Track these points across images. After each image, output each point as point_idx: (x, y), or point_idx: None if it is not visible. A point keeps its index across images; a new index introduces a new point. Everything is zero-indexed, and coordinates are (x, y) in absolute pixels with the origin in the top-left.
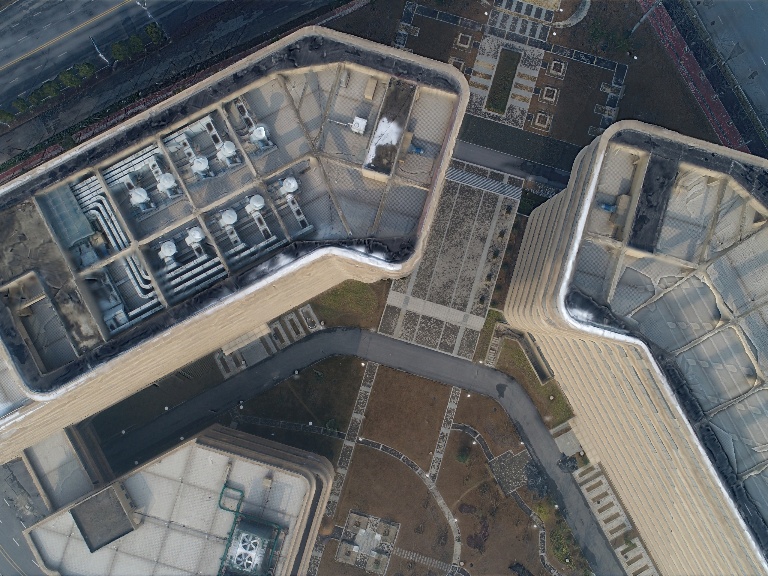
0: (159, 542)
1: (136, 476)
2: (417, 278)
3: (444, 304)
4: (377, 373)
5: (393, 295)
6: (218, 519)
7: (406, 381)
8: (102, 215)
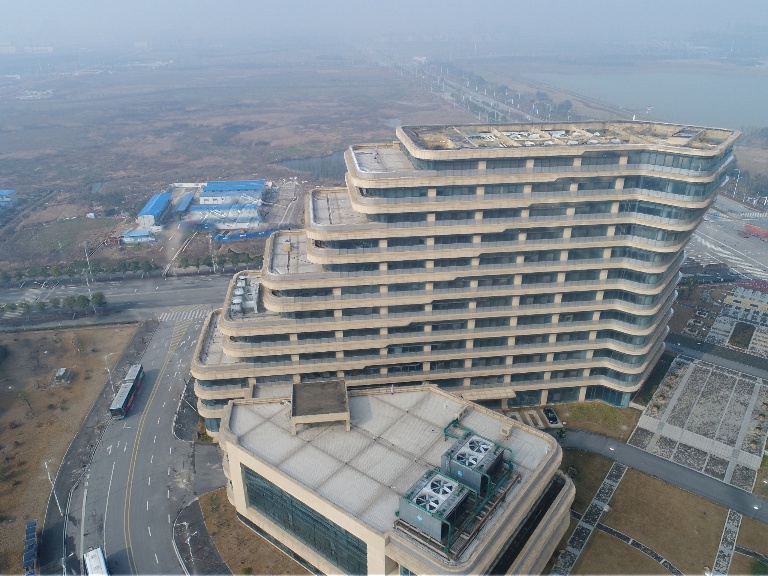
0: (358, 449)
1: (363, 398)
2: (672, 413)
3: (706, 436)
4: (626, 473)
5: (645, 419)
6: (435, 449)
7: (664, 488)
8: (489, 138)
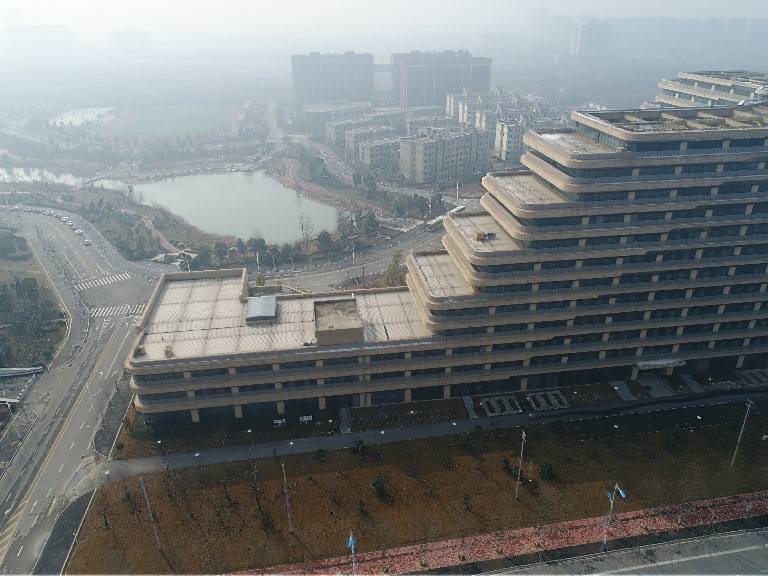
0: None
1: None
2: None
3: None
4: None
5: None
6: None
7: None
8: None
